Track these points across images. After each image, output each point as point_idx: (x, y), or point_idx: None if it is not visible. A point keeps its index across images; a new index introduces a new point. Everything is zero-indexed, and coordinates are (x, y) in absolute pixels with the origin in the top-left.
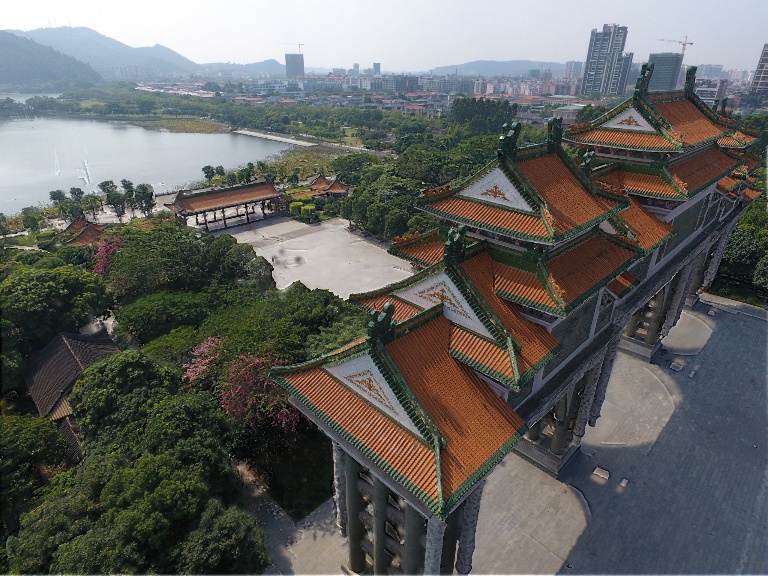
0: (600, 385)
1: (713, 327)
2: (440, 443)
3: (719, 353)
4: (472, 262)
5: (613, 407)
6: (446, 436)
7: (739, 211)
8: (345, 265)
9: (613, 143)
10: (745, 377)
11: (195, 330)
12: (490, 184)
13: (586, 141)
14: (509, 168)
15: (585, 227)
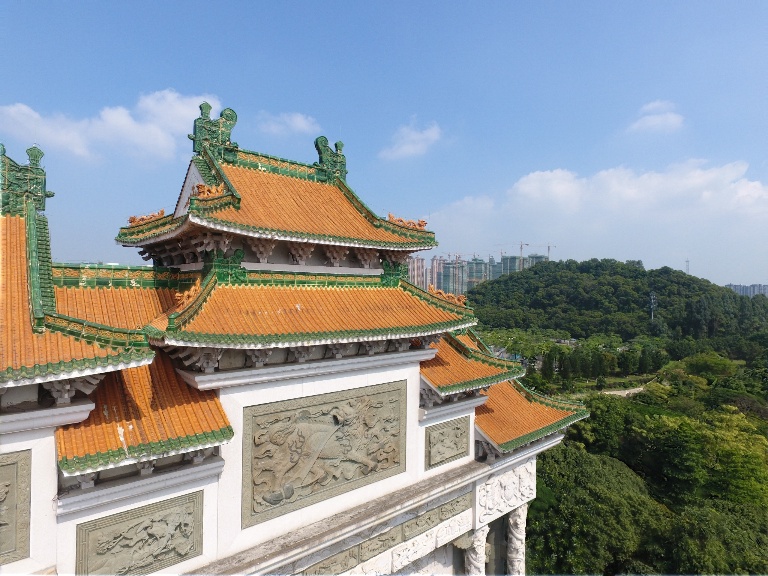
0: None
1: None
2: None
3: None
4: None
5: None
6: None
7: None
8: None
9: None
10: None
11: None
12: None
13: None
14: None
15: None
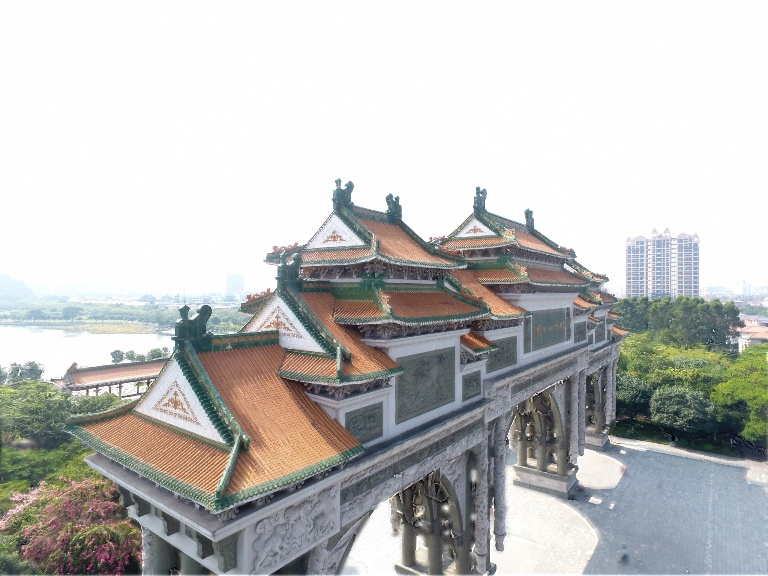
0: (497, 490)
1: (626, 464)
2: (240, 440)
3: (635, 485)
4: (311, 295)
5: (532, 545)
6: (254, 441)
7: (612, 343)
8: None
9: (464, 246)
10: (664, 505)
11: (32, 487)
12: (329, 231)
13: None
14: (344, 214)
15: (417, 263)
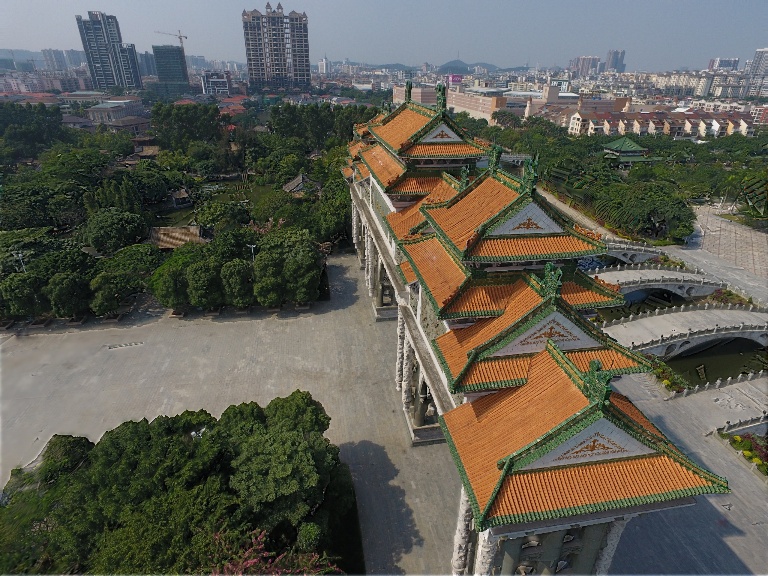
0: None
1: None
2: None
3: None
4: None
5: None
6: None
7: None
8: (29, 380)
9: (440, 155)
10: None
11: None
12: (523, 218)
13: (418, 156)
14: (537, 200)
15: None
